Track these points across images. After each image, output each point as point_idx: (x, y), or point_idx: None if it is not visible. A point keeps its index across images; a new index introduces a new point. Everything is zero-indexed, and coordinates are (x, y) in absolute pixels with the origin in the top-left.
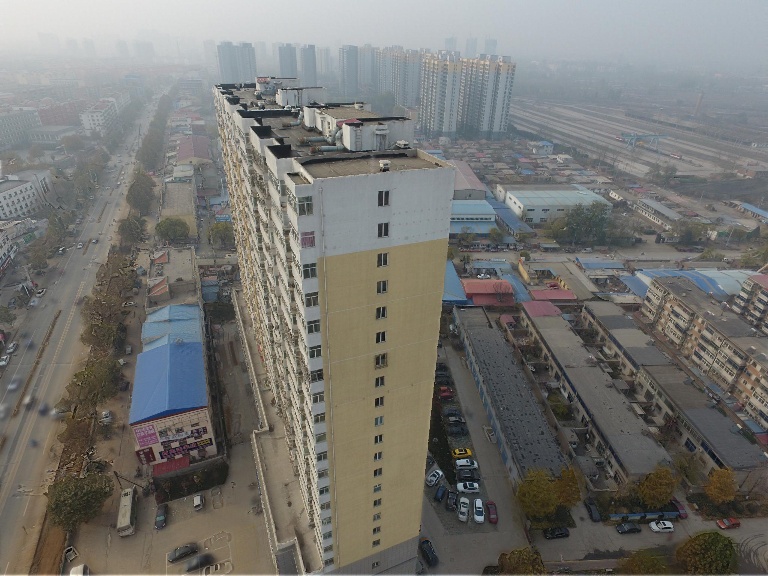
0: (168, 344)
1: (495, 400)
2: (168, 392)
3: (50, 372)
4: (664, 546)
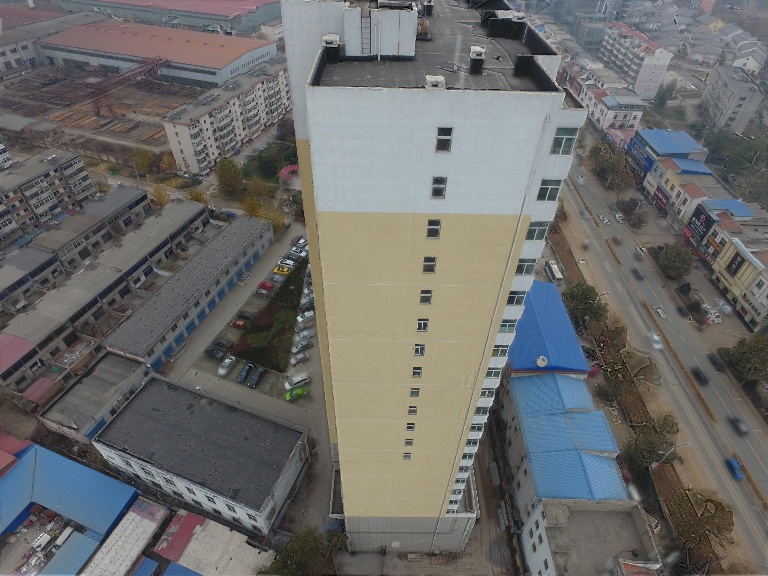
0: (554, 363)
1: (226, 266)
2: (530, 295)
3: (763, 545)
4: (223, 207)
